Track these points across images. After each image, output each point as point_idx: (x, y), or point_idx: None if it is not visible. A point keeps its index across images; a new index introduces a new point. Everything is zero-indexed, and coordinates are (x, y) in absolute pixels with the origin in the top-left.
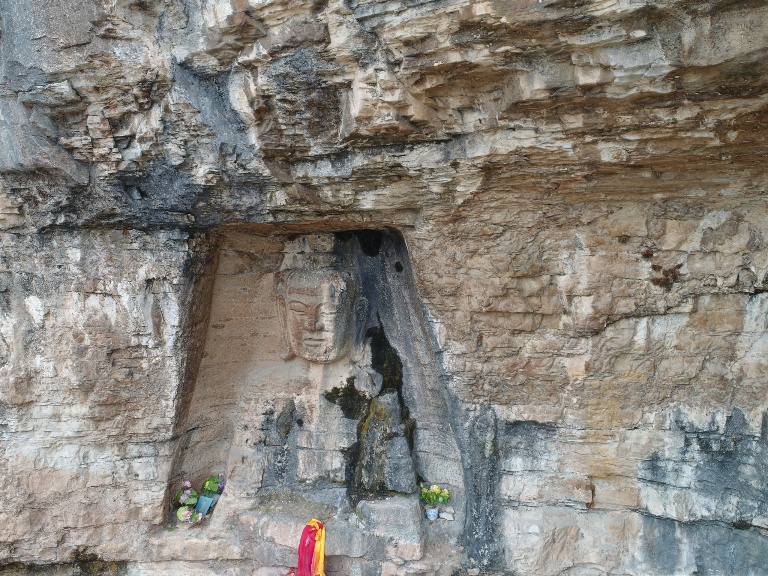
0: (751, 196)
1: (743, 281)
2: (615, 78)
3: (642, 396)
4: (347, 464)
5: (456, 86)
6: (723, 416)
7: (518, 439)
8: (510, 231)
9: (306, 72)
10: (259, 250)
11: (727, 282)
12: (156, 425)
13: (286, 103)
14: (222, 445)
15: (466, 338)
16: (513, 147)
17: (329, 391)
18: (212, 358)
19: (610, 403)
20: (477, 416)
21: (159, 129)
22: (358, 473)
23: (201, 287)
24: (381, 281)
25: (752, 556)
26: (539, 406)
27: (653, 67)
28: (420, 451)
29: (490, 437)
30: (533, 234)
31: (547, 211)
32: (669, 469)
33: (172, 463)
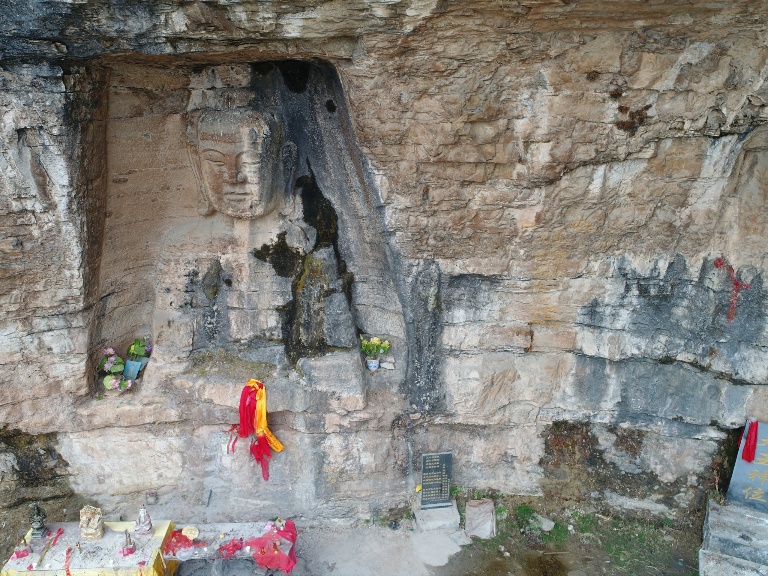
0: (742, 25)
1: (710, 123)
2: None
3: (589, 245)
4: (283, 322)
5: None
6: (665, 262)
7: (461, 291)
8: (466, 66)
9: None
10: (158, 86)
11: (695, 125)
12: (62, 297)
13: None
14: (143, 308)
15: (411, 191)
16: None
17: (258, 249)
18: (118, 217)
19: (557, 254)
20: (420, 271)
21: None
22: (296, 331)
23: (90, 136)
24: (310, 123)
25: (672, 386)
26: (485, 259)
27: None
28: (359, 304)
29: (433, 291)
30: (492, 70)
31: (511, 42)
32: (607, 314)
33: (89, 333)
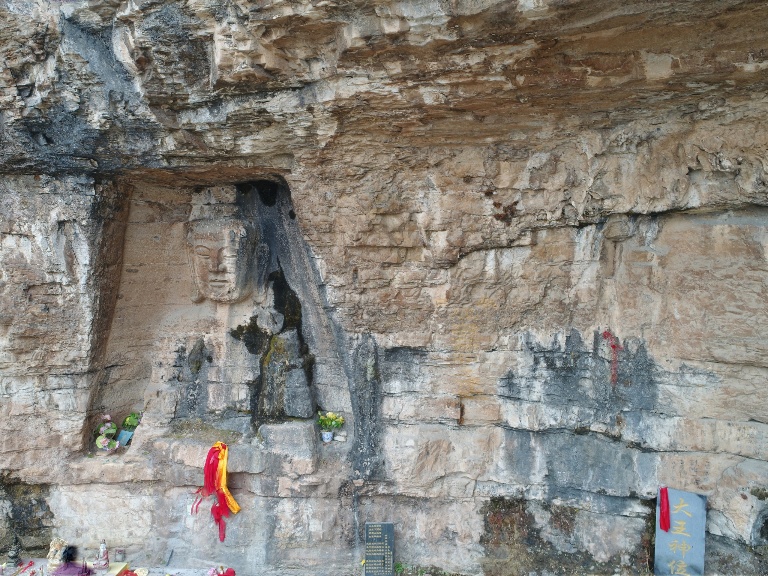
0: (561, 138)
1: (569, 215)
2: (411, 27)
3: (497, 321)
4: (252, 395)
5: (298, 38)
6: (563, 336)
7: (397, 365)
8: (371, 173)
9: (174, 26)
10: (168, 201)
11: (554, 216)
12: (73, 357)
13: (162, 54)
14: (142, 384)
15: (343, 271)
16: (353, 92)
17: (234, 329)
18: (127, 300)
19: (470, 328)
20: (360, 344)
21: (55, 78)
22: (261, 402)
23: (111, 231)
24: (279, 229)
25: (590, 457)
26: (411, 333)
27: (435, 17)
28: (319, 384)
29: (371, 362)
30: (391, 175)
31: (399, 154)
32: (522, 385)
33: (91, 395)
